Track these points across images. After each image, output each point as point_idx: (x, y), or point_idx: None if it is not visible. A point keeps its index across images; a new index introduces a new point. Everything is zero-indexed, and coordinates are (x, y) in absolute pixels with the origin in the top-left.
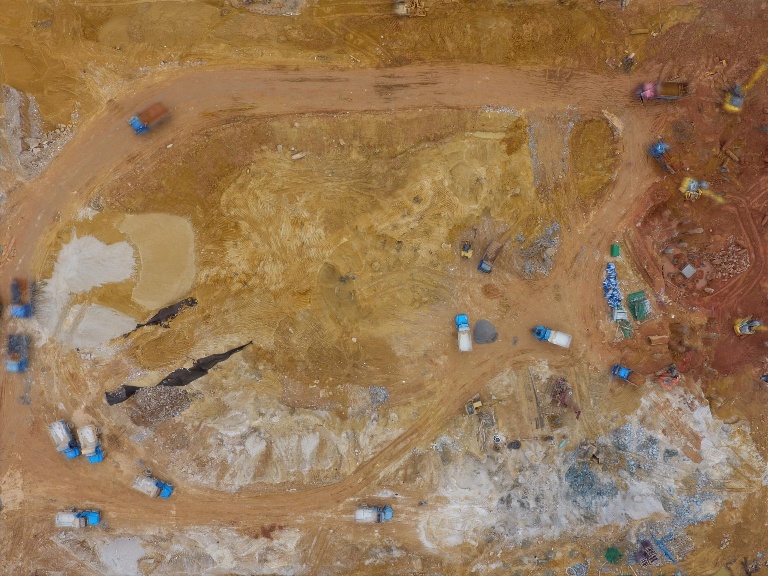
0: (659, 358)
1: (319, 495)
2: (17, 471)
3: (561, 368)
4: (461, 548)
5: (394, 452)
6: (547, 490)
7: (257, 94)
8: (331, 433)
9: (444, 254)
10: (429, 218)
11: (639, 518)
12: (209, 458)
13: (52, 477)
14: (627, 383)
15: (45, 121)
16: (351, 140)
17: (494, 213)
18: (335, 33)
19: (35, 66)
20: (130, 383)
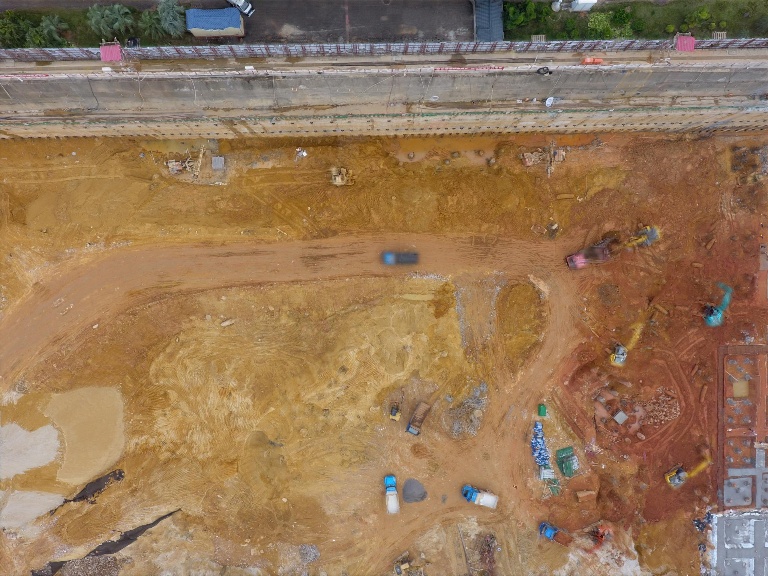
0: (586, 515)
1: None
2: None
3: (490, 524)
4: None
5: None
6: None
7: (183, 271)
8: None
9: (373, 416)
10: (355, 386)
11: None
12: None
13: None
14: None
15: None
16: (280, 306)
17: (423, 374)
18: (264, 202)
19: None
20: (56, 559)
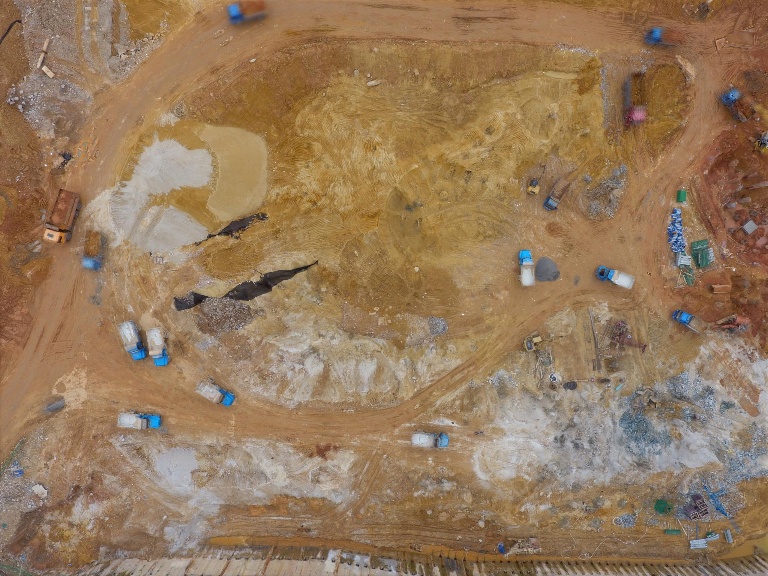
0: (721, 307)
1: (375, 418)
2: (82, 370)
3: (621, 311)
4: (514, 482)
5: (451, 382)
6: (601, 433)
7: (340, 17)
8: (389, 360)
9: (511, 189)
10: (500, 150)
11: (694, 467)
12: (270, 372)
13: (116, 379)
14: (687, 330)
15: (134, 30)
16: (426, 71)
17: (562, 152)
18: None
19: None
20: (198, 291)
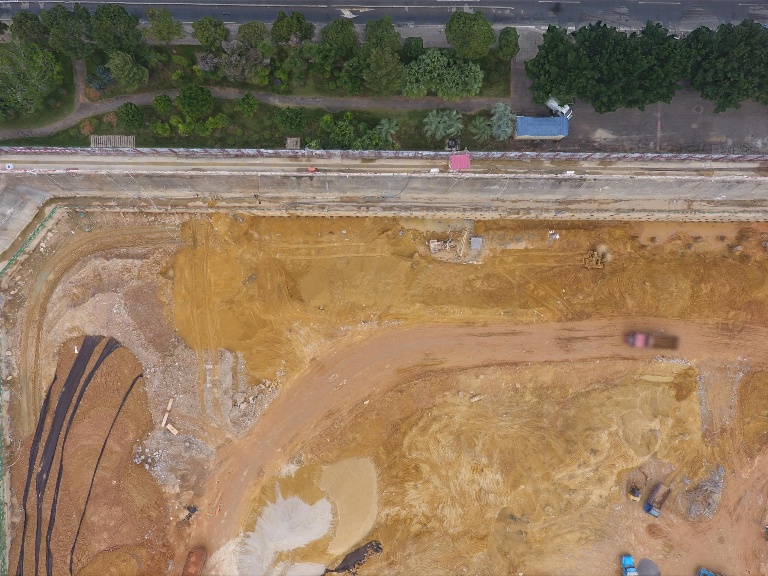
0: None
1: None
2: None
3: None
4: None
5: None
6: None
7: (447, 349)
8: None
9: (612, 495)
10: (604, 468)
11: None
12: None
13: None
14: None
15: (250, 375)
16: (526, 383)
17: (660, 455)
18: (515, 281)
19: (245, 325)
20: None
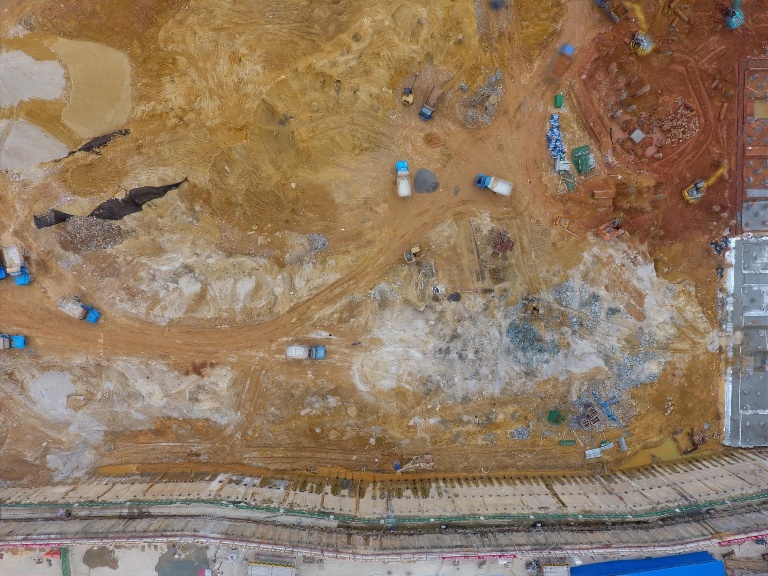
0: (602, 212)
1: (252, 334)
2: None
3: (503, 220)
4: (395, 392)
5: (330, 296)
6: (487, 344)
7: None
8: (267, 277)
9: (385, 100)
10: (368, 57)
11: (579, 372)
12: (139, 290)
13: None
14: (570, 237)
15: None
16: None
17: (437, 61)
18: None
19: None
20: (59, 208)
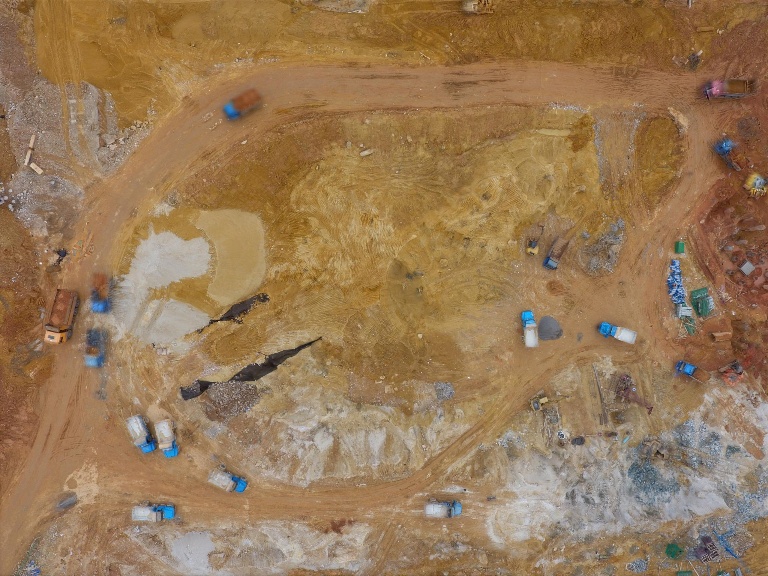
0: (722, 355)
1: (388, 490)
2: (92, 465)
3: (625, 364)
4: (528, 543)
5: (461, 448)
6: (610, 486)
7: (329, 91)
8: (398, 429)
9: (510, 251)
10: (497, 215)
11: (703, 514)
12: (281, 453)
13: (127, 471)
14: (690, 379)
15: (121, 118)
16: (418, 137)
17: (559, 210)
18: (403, 30)
19: (111, 63)
20: (204, 378)
